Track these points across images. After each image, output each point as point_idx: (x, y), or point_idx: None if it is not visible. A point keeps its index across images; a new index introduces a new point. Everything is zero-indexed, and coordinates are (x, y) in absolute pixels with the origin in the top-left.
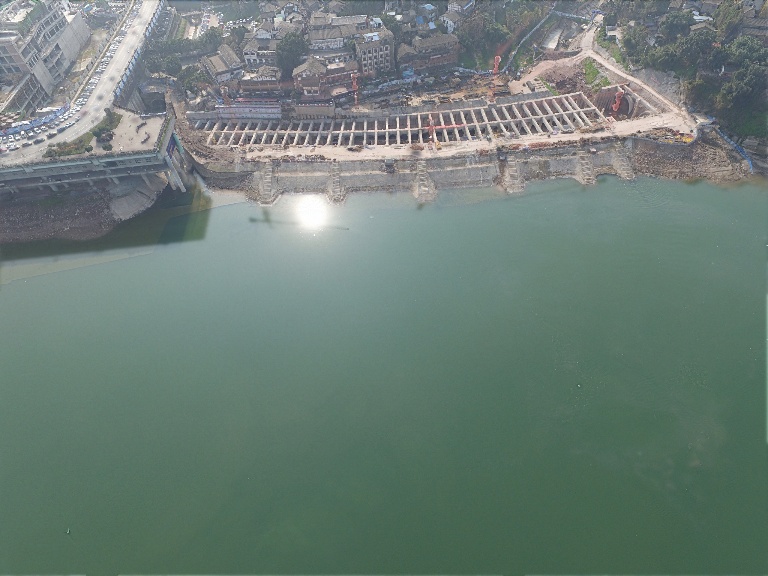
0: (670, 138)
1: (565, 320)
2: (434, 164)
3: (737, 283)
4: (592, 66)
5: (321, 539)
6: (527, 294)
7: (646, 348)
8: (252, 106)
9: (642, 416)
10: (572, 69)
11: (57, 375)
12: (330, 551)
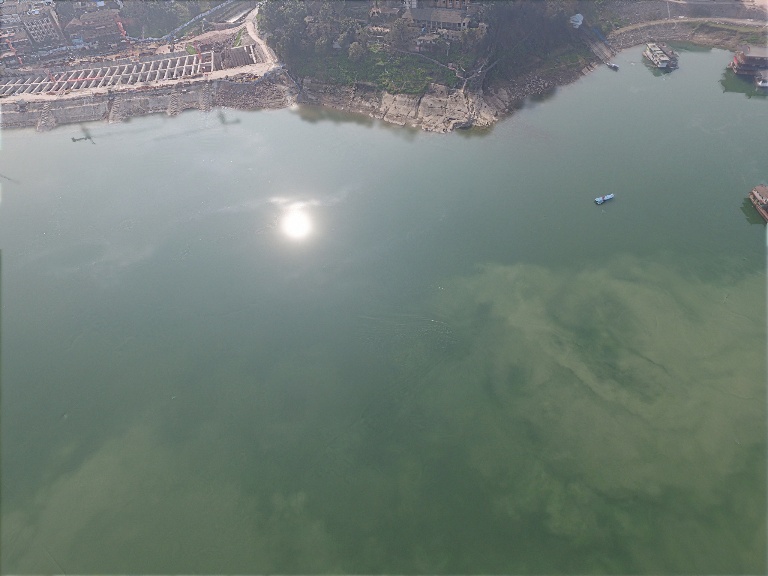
0: (244, 80)
1: (75, 198)
2: (57, 104)
3: (215, 171)
4: (240, 33)
5: None
6: (63, 185)
7: (117, 212)
8: None
9: None
10: (227, 36)
11: None
12: None
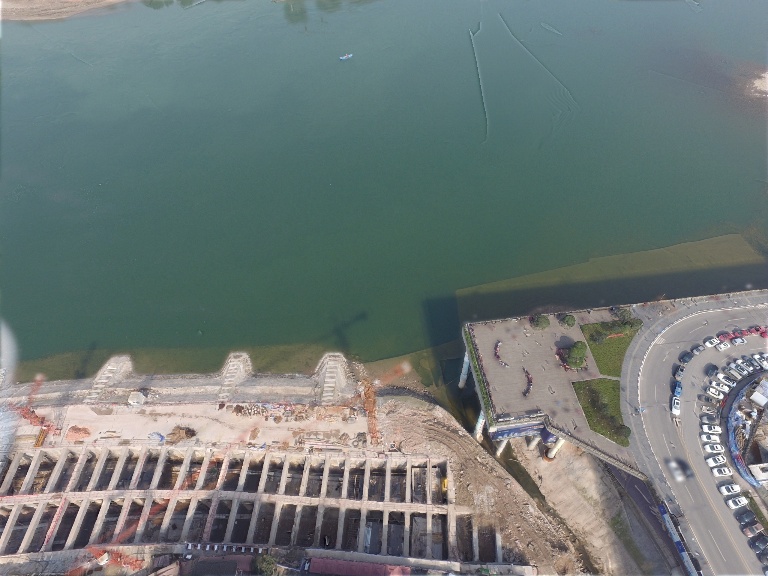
0: None
1: (72, 226)
2: (73, 400)
3: None
4: None
5: (281, 135)
6: (86, 245)
7: (31, 210)
8: (370, 555)
9: (75, 176)
10: None
11: (445, 153)
12: (277, 132)
